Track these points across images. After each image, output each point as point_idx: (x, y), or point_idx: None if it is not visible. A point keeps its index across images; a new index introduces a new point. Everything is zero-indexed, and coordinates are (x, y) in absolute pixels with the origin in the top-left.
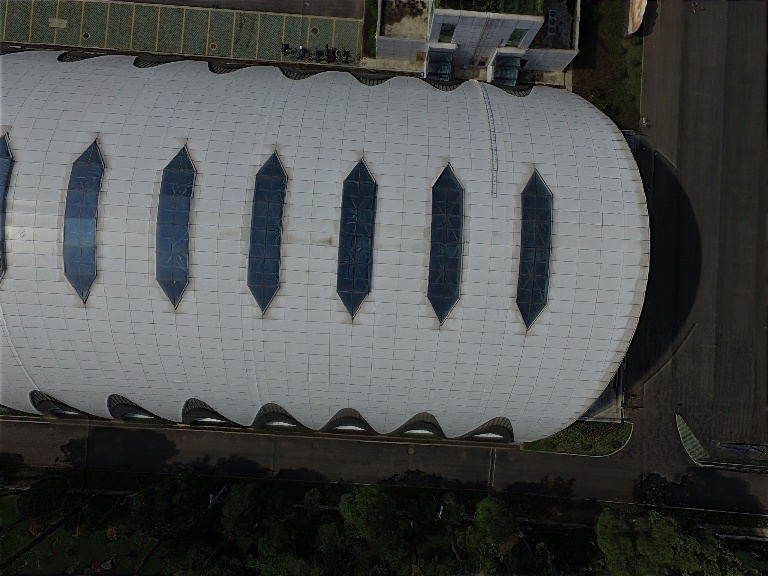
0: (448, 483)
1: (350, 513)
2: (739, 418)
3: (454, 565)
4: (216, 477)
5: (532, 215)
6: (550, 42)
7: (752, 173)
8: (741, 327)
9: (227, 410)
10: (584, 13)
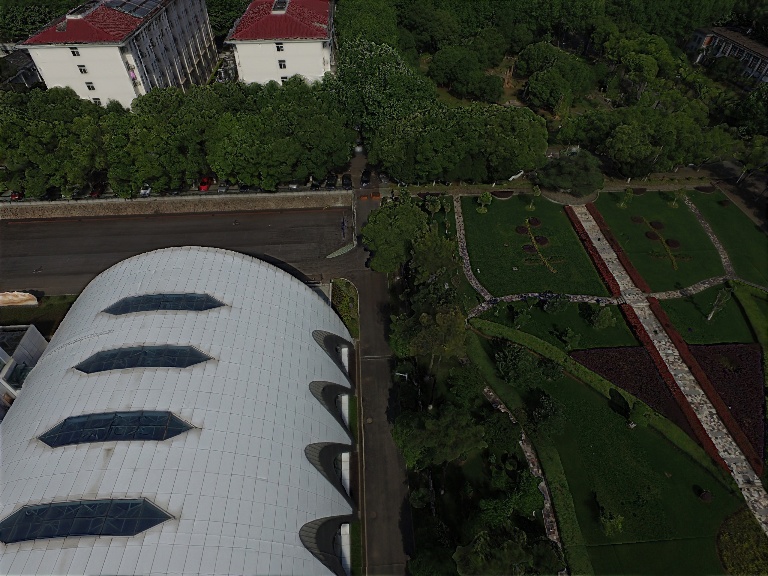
0: None
1: None
2: (327, 232)
3: None
4: None
5: (136, 308)
6: (14, 343)
7: (168, 237)
8: (269, 235)
9: None
10: None
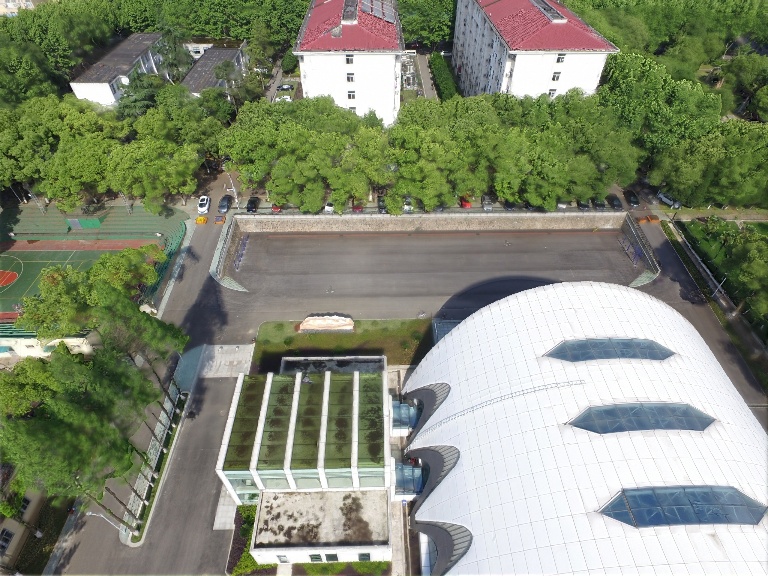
0: None
1: None
2: (612, 257)
3: None
4: None
5: (585, 354)
6: None
7: (445, 258)
8: (551, 258)
9: None
10: None
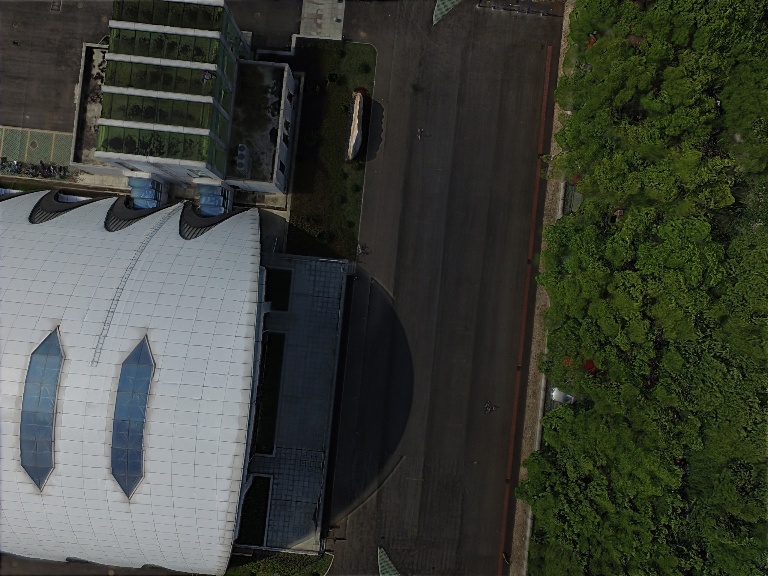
0: None
1: None
2: (443, 554)
3: None
4: None
5: None
6: (248, 173)
7: (470, 305)
8: (450, 461)
9: None
10: (303, 137)
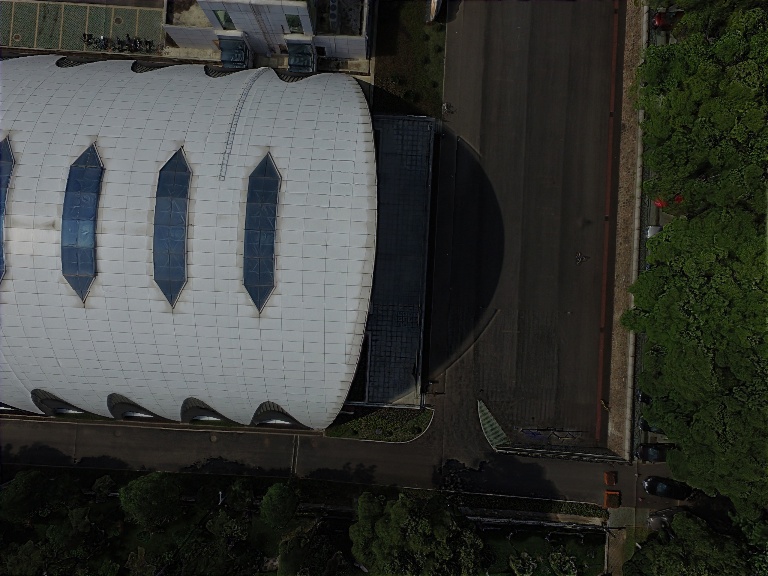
0: (250, 470)
1: (123, 499)
2: (542, 404)
3: (195, 548)
4: (18, 465)
5: (261, 198)
6: (338, 28)
7: (556, 158)
8: (544, 312)
9: (1, 397)
10: None
